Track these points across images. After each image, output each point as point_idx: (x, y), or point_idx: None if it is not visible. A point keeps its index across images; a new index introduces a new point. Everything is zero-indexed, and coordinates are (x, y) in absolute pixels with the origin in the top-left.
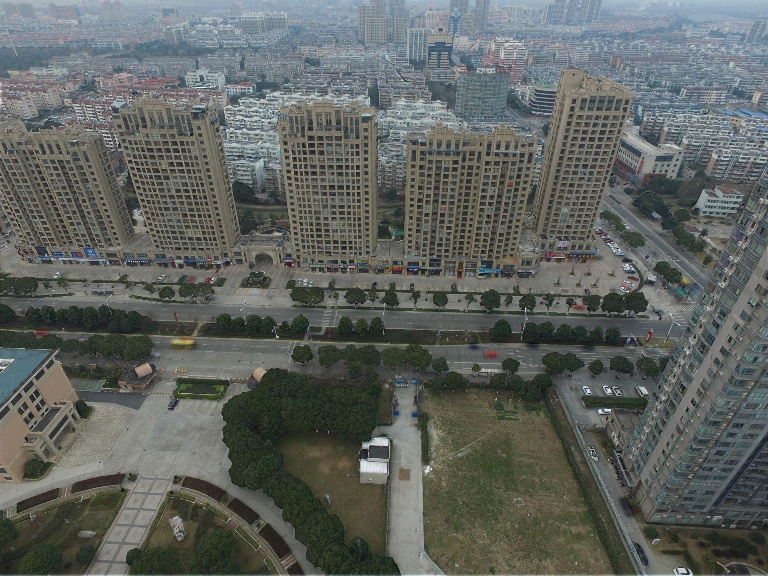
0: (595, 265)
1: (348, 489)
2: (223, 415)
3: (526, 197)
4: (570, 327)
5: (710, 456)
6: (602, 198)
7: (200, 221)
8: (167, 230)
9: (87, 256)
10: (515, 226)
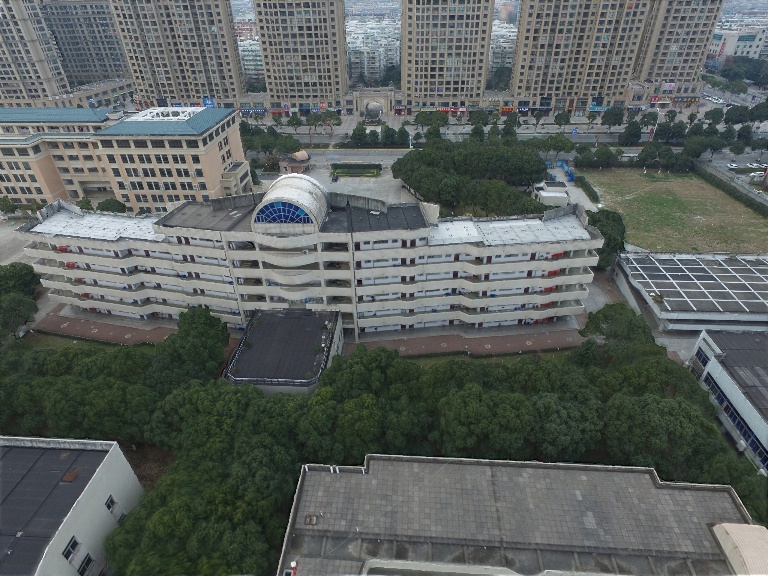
0: (700, 109)
1: None
2: (395, 169)
3: (643, 23)
4: (702, 126)
5: None
6: (712, 33)
7: (318, 64)
8: (284, 75)
9: None
10: (628, 58)
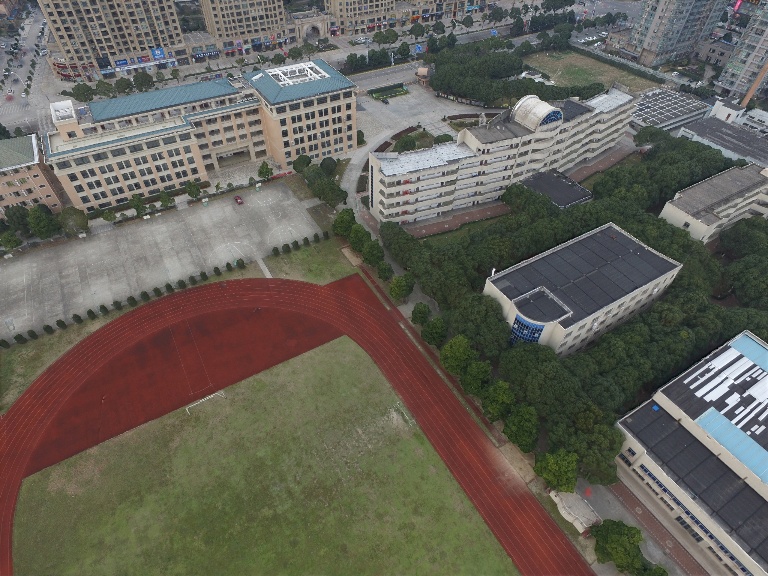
0: None
1: None
2: (438, 84)
3: None
4: None
5: (685, 1)
6: None
7: None
8: (232, 12)
9: (154, 59)
10: None
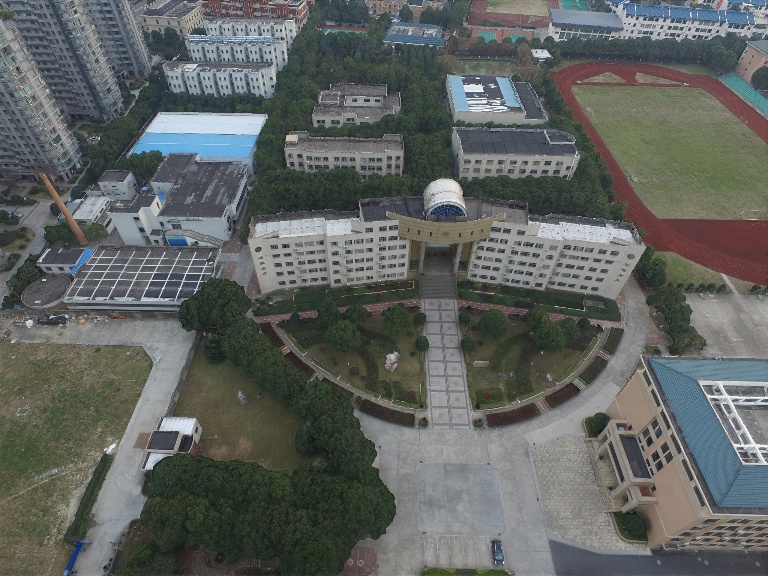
0: None
1: (218, 419)
2: None
3: None
4: None
5: None
6: None
7: None
8: None
9: None
10: None
